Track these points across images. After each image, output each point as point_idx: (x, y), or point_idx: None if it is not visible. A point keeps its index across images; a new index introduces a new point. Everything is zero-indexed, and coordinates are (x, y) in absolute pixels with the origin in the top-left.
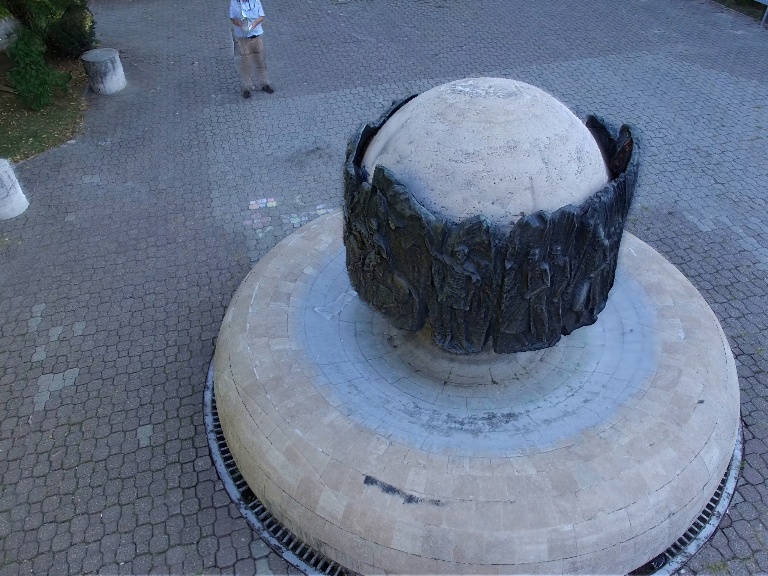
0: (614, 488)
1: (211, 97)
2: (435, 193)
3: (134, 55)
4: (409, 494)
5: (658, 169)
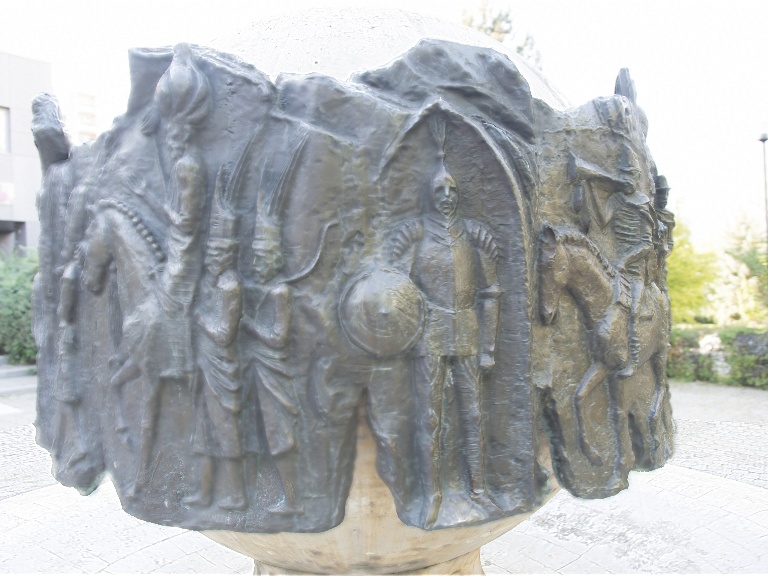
0: None
1: None
2: None
3: None
4: None
5: None
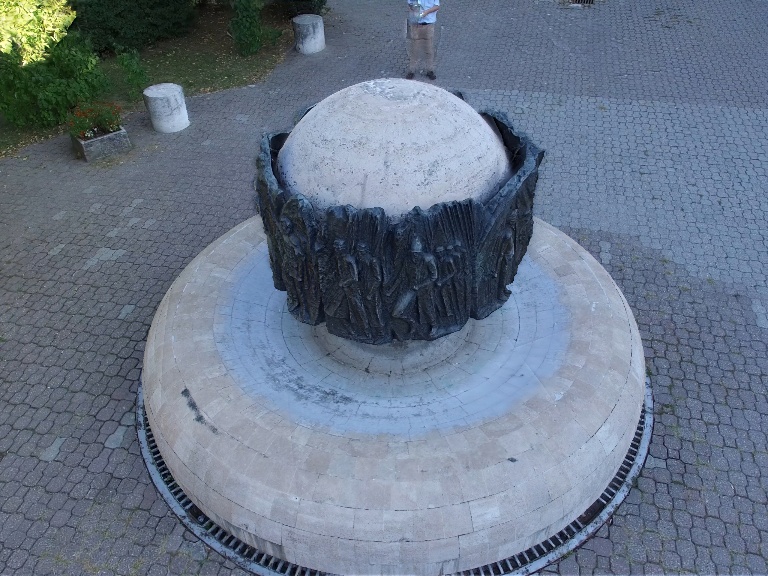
0: (356, 488)
1: (380, 72)
2: (294, 168)
3: (349, 25)
4: (201, 414)
5: (767, 247)
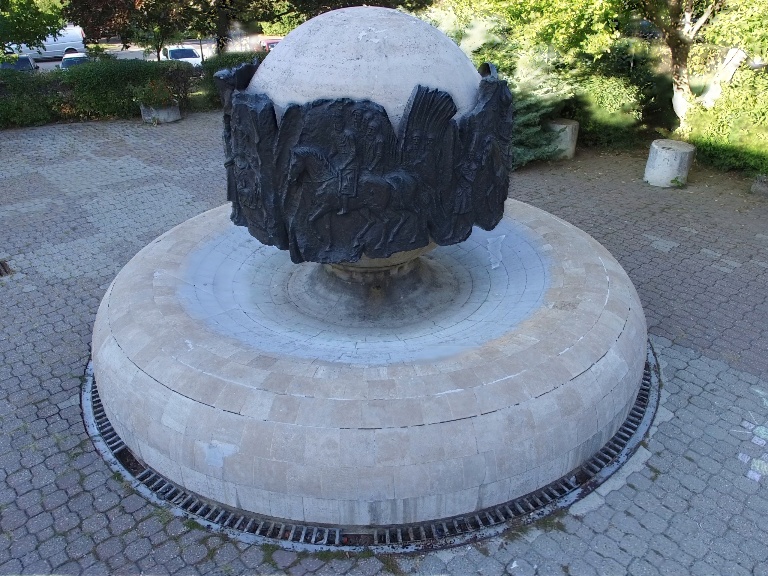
0: None
1: None
2: None
3: None
4: None
5: None
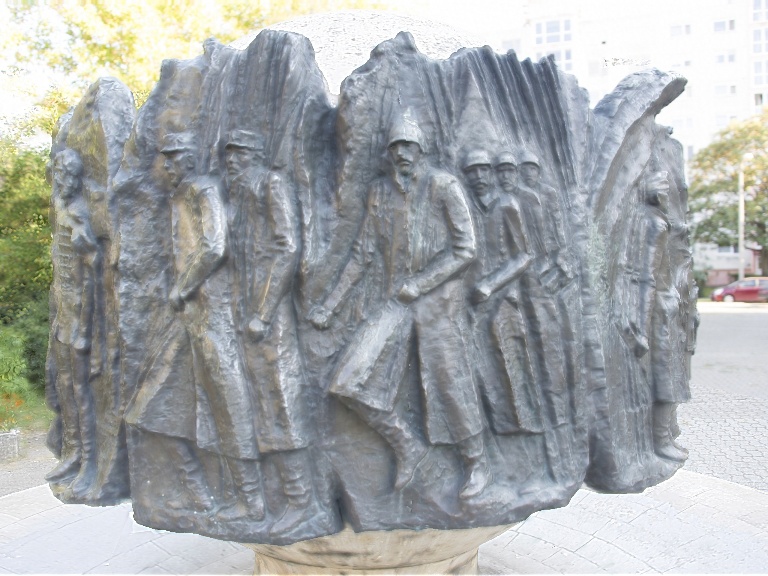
0: None
1: None
2: None
3: None
4: None
5: None
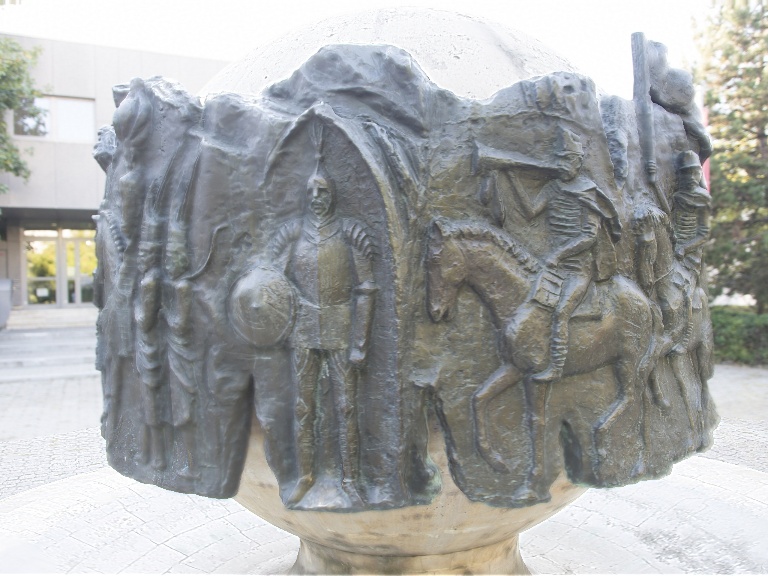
0: None
1: None
2: None
3: None
4: None
5: None
